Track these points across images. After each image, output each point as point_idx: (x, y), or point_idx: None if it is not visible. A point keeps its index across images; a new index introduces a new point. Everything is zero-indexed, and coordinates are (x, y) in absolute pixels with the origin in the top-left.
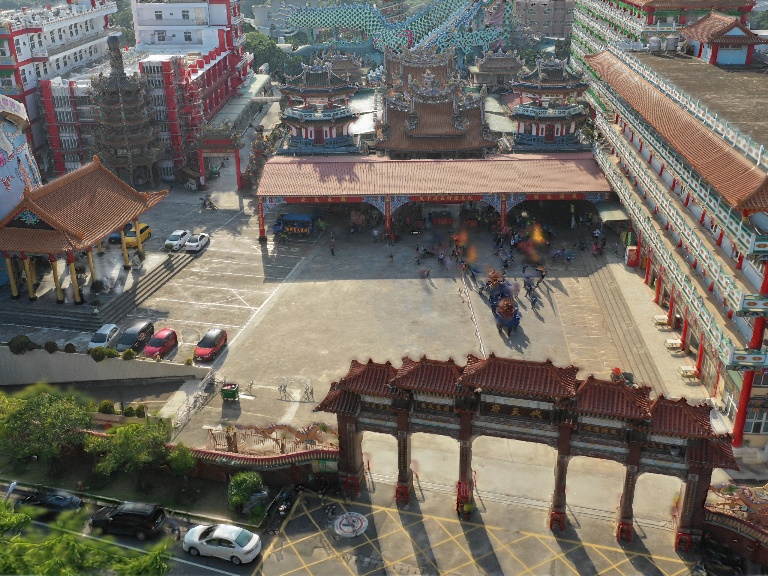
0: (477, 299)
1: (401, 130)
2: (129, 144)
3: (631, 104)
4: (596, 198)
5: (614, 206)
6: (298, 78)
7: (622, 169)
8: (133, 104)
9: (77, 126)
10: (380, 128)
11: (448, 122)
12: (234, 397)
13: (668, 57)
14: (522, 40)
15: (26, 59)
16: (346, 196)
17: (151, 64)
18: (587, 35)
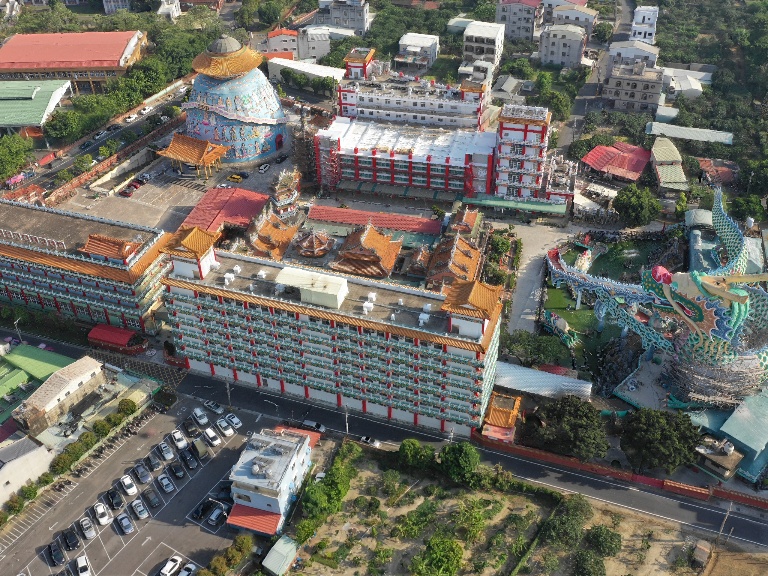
0: None
1: None
2: None
3: None
4: None
5: None
6: None
7: None
8: None
9: None
10: None
11: None
12: None
13: None
14: None
15: (352, 103)
16: None
17: None
18: None
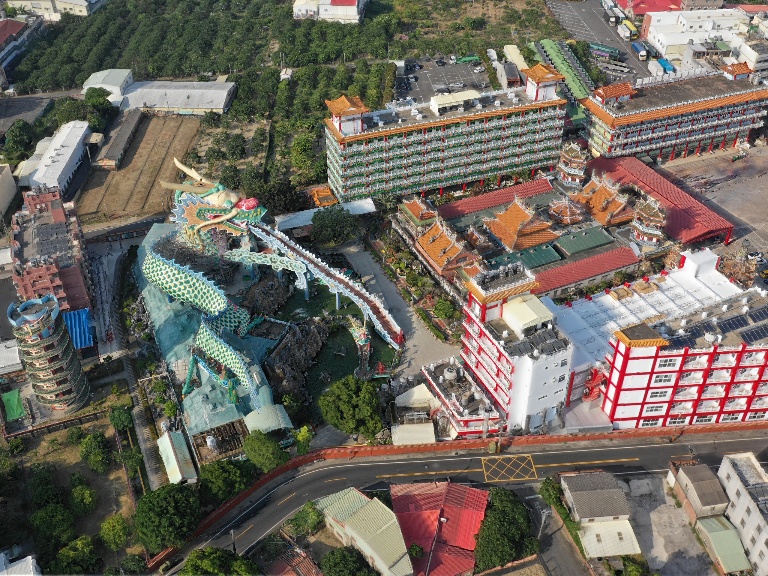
0: None
1: None
2: None
3: None
4: None
5: None
6: None
7: None
8: None
9: None
10: (611, 222)
11: None
12: None
13: (623, 106)
14: None
15: None
16: None
17: None
18: None
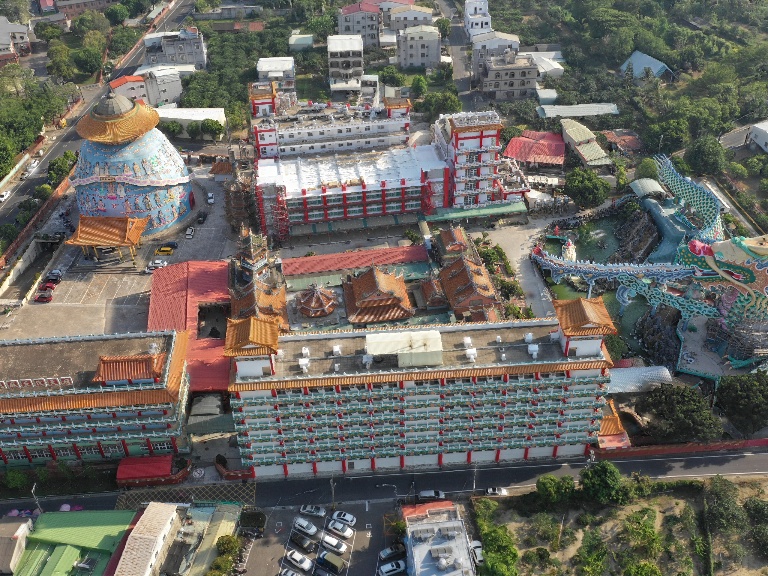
0: None
1: None
2: None
3: None
4: None
5: None
6: None
7: None
8: None
9: None
10: None
11: None
12: (6, 312)
13: None
14: None
15: (271, 143)
16: None
17: None
18: None
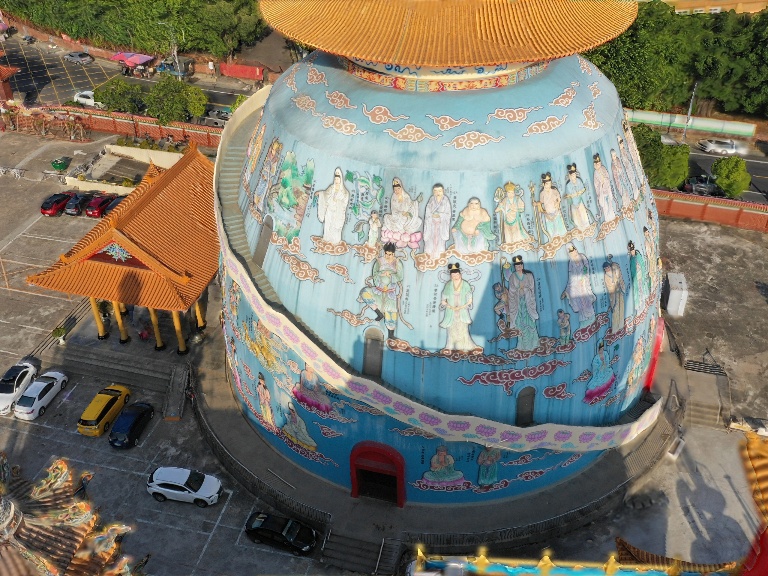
0: None
1: None
2: None
3: None
4: None
5: None
6: None
7: None
8: None
9: None
10: None
11: None
12: None
13: None
14: None
15: None
16: None
17: None
18: None
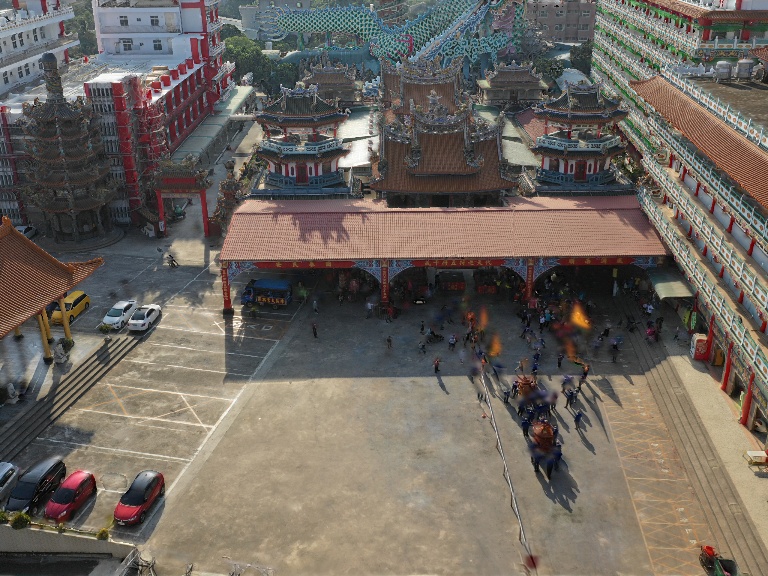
0: (502, 412)
1: (401, 167)
2: (70, 184)
3: (717, 163)
4: (647, 263)
5: (671, 275)
6: (276, 104)
7: (681, 228)
8: (74, 136)
9: (12, 159)
10: (376, 161)
11: (458, 157)
12: None
13: (742, 87)
14: (534, 46)
15: None
16: (332, 260)
17: (99, 86)
18: (614, 46)
